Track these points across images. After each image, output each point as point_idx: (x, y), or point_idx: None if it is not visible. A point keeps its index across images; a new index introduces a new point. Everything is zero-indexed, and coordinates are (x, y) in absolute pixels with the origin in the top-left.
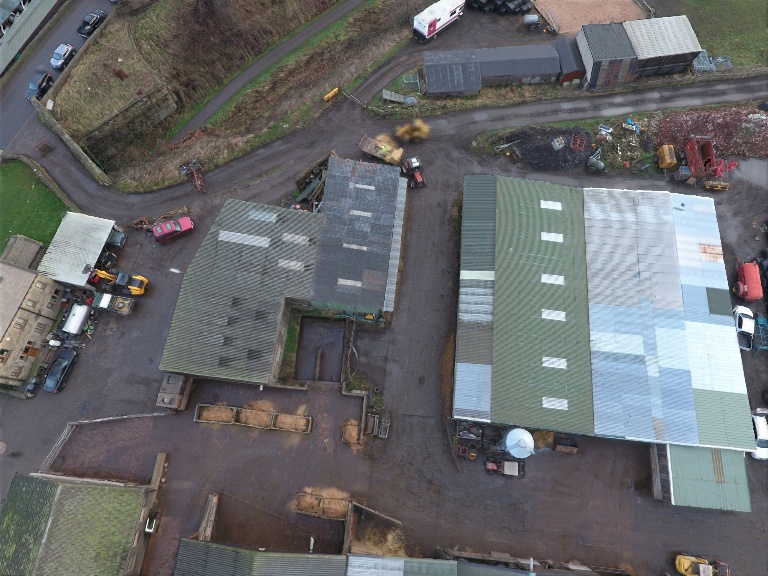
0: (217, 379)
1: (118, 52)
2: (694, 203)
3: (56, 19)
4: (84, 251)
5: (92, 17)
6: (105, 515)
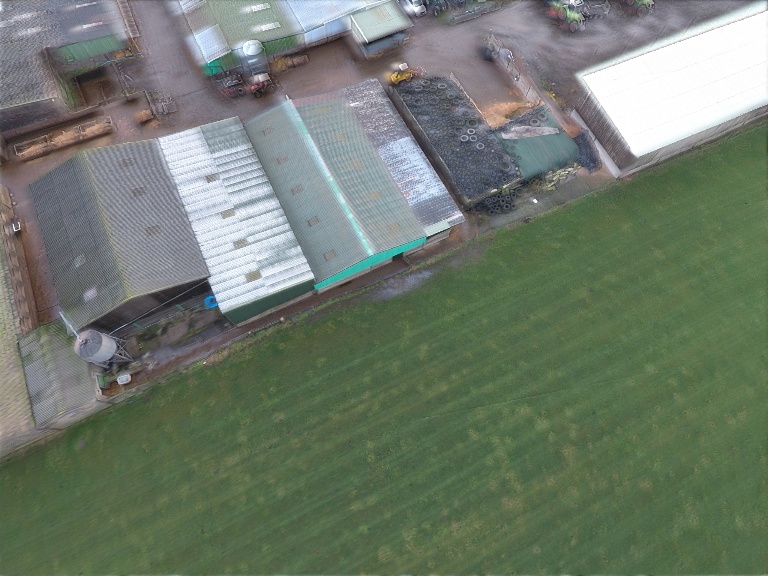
0: (23, 129)
1: None
2: None
3: None
4: None
5: None
6: None
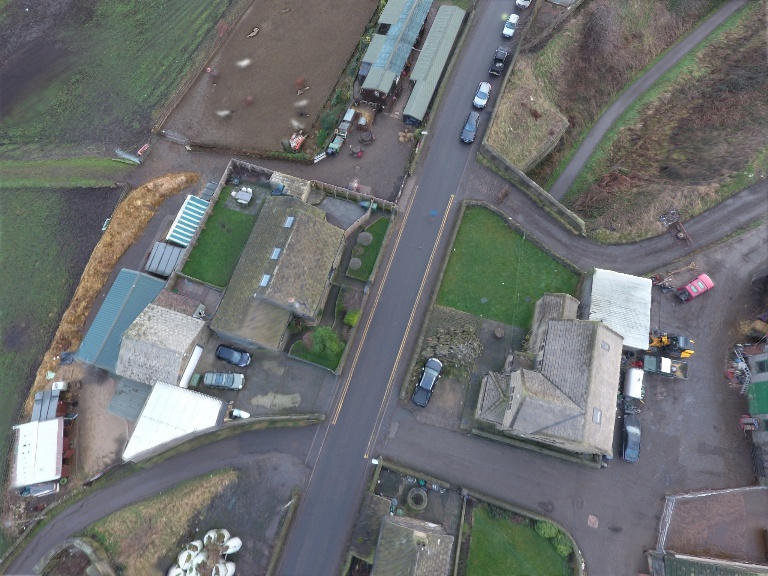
0: None
1: (530, 91)
2: None
3: (457, 55)
4: (632, 312)
5: (505, 54)
6: None
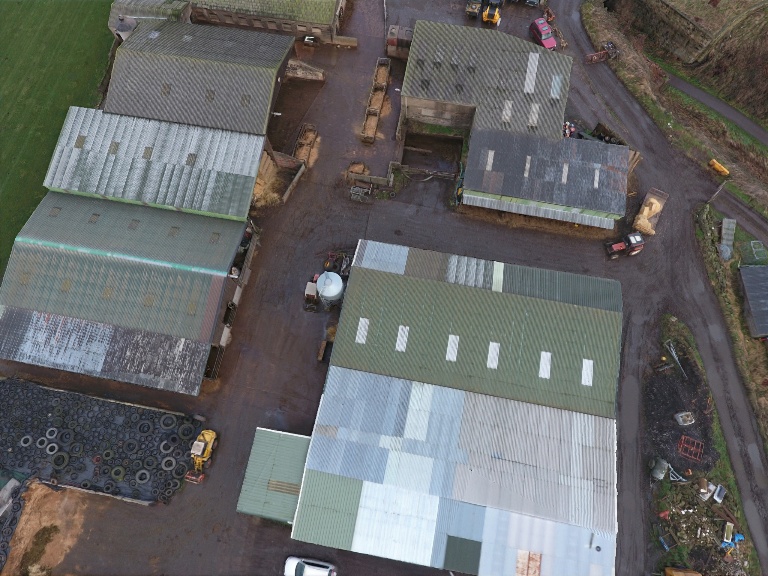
0: None
1: None
2: (603, 568)
3: None
4: None
5: None
6: (318, 1)
